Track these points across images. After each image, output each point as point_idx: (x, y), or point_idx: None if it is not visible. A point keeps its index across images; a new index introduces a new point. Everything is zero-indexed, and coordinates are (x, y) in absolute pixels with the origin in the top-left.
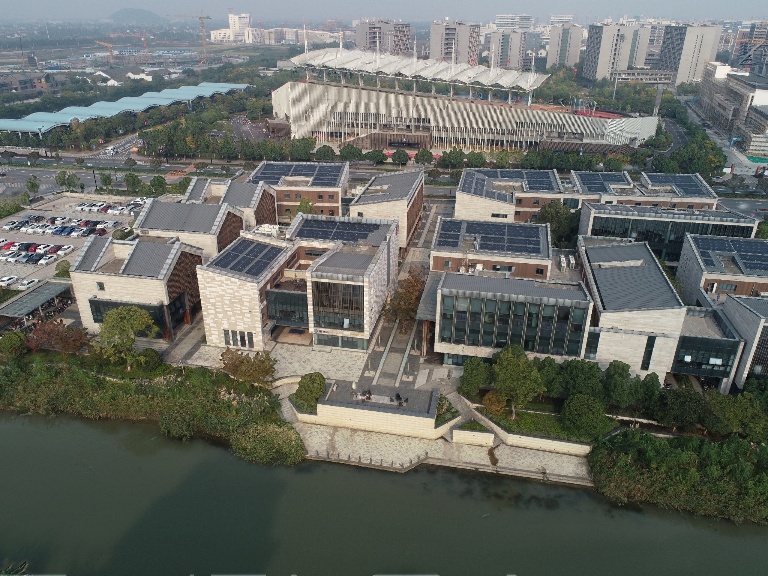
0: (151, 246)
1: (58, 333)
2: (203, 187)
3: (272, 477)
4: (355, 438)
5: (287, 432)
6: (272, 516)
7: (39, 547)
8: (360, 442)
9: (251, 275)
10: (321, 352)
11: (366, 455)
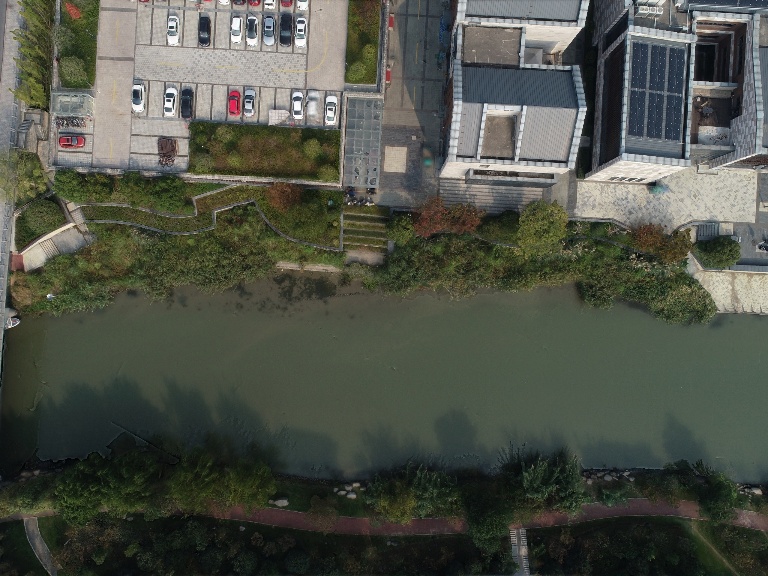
0: (544, 114)
1: (442, 214)
2: None
3: (692, 335)
4: (753, 285)
5: (698, 292)
6: (704, 373)
7: (555, 425)
8: (758, 289)
9: (673, 141)
10: (708, 175)
11: (765, 304)
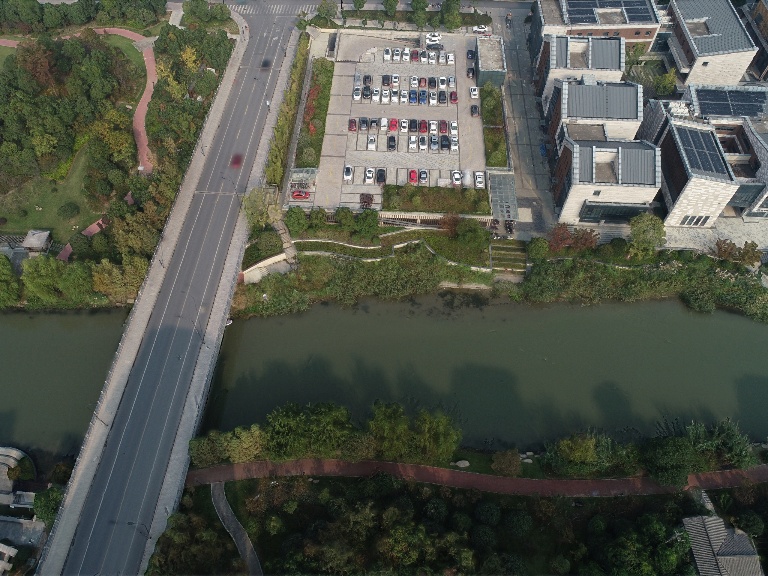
0: (633, 153)
1: None
2: (564, 47)
3: None
4: None
5: None
6: None
7: (699, 402)
8: None
9: (722, 174)
10: (752, 223)
11: None
